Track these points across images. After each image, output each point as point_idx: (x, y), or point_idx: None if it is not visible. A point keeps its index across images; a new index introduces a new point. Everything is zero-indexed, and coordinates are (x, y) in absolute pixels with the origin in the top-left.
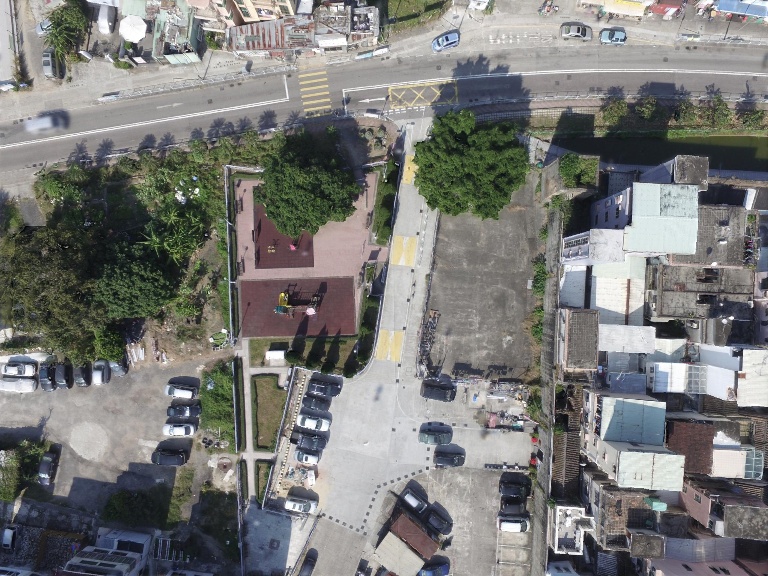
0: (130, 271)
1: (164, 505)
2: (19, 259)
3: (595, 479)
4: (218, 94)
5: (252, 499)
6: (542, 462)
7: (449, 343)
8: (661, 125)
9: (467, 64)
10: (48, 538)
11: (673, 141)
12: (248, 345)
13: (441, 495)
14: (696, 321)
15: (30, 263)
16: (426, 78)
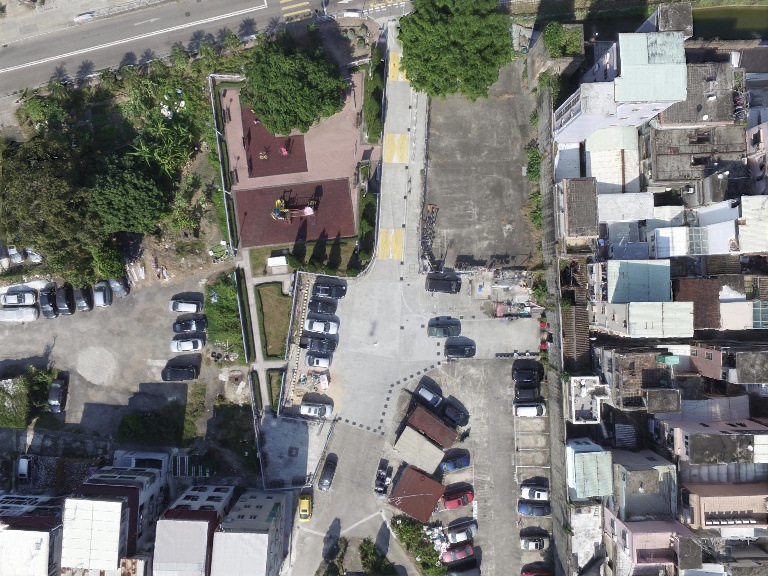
0: (122, 180)
1: (178, 422)
2: (8, 168)
3: (606, 349)
4: (195, 6)
5: (266, 409)
6: (552, 342)
7: (450, 236)
8: (641, 2)
9: None
10: (64, 466)
11: None
12: (248, 255)
13: (455, 388)
14: (692, 186)
15: (20, 171)
16: None
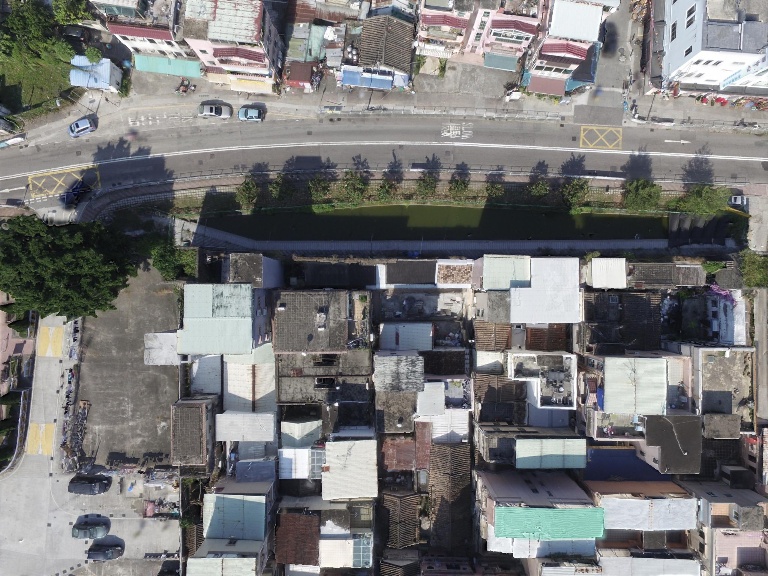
0: None
1: None
2: None
3: None
4: None
5: None
6: None
7: (102, 433)
8: (308, 199)
9: (108, 148)
10: None
11: (323, 214)
12: None
13: None
14: None
15: None
16: (66, 164)
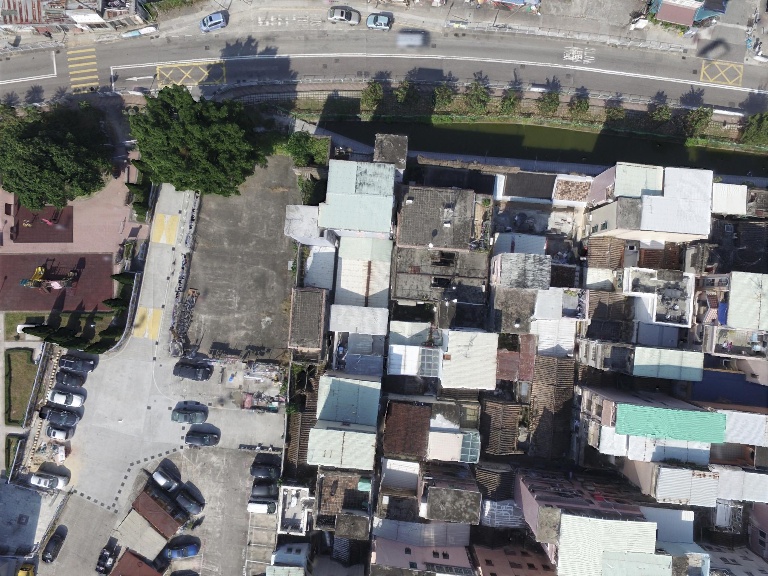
0: None
1: None
2: None
3: None
4: None
5: (3, 473)
6: None
7: (207, 322)
8: (427, 111)
9: (236, 45)
10: None
11: (440, 127)
12: (3, 319)
13: (194, 475)
14: (436, 305)
15: None
16: (194, 58)
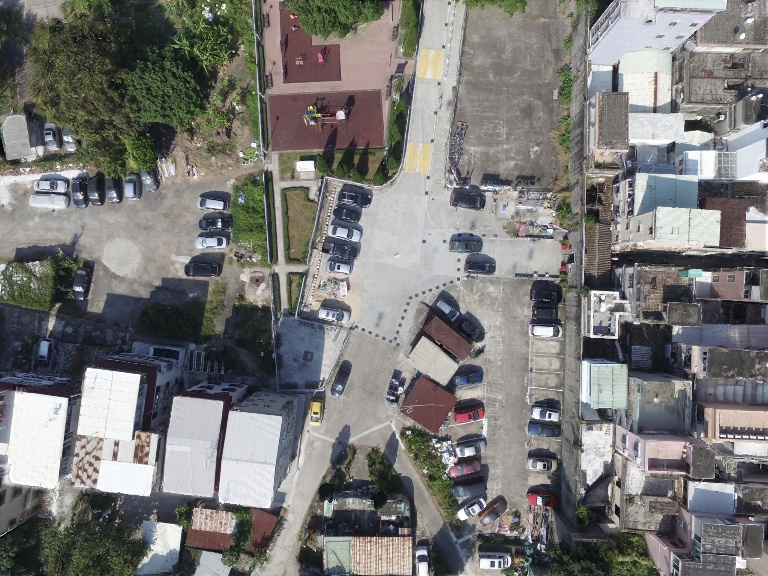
0: (162, 68)
1: (198, 318)
2: (55, 40)
3: (628, 266)
4: None
5: (285, 312)
6: (573, 262)
7: (477, 154)
8: None
9: None
10: (83, 353)
11: None
12: (278, 159)
13: (473, 305)
14: (724, 112)
15: (65, 45)
16: None
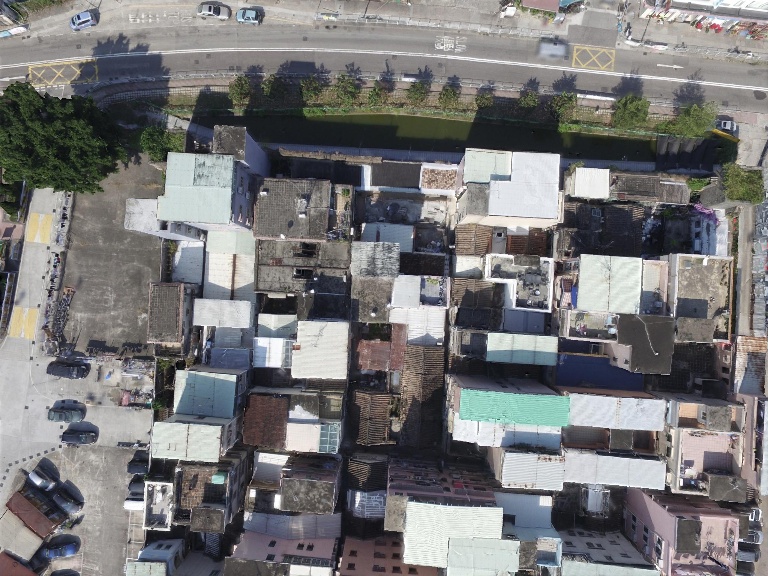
0: None
1: None
2: None
3: None
4: None
5: None
6: None
7: (83, 320)
8: (300, 103)
9: (107, 43)
10: None
11: (314, 119)
12: None
13: (73, 473)
14: None
15: None
16: (66, 57)
